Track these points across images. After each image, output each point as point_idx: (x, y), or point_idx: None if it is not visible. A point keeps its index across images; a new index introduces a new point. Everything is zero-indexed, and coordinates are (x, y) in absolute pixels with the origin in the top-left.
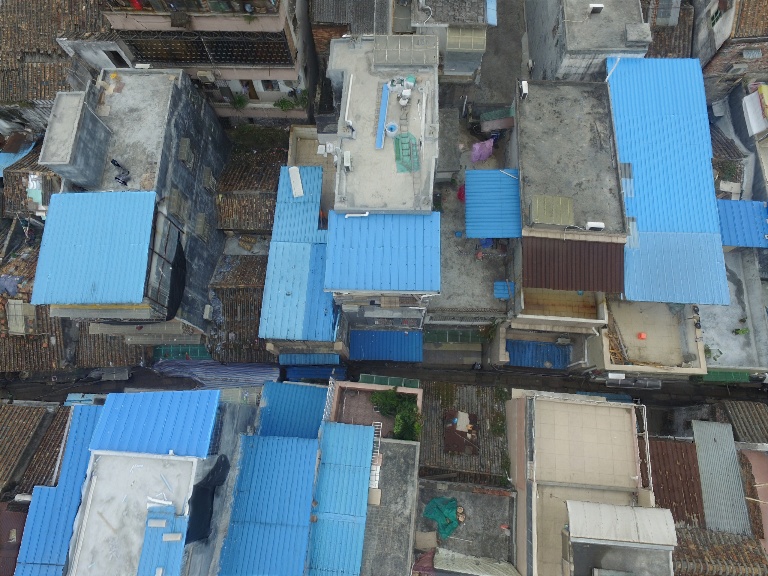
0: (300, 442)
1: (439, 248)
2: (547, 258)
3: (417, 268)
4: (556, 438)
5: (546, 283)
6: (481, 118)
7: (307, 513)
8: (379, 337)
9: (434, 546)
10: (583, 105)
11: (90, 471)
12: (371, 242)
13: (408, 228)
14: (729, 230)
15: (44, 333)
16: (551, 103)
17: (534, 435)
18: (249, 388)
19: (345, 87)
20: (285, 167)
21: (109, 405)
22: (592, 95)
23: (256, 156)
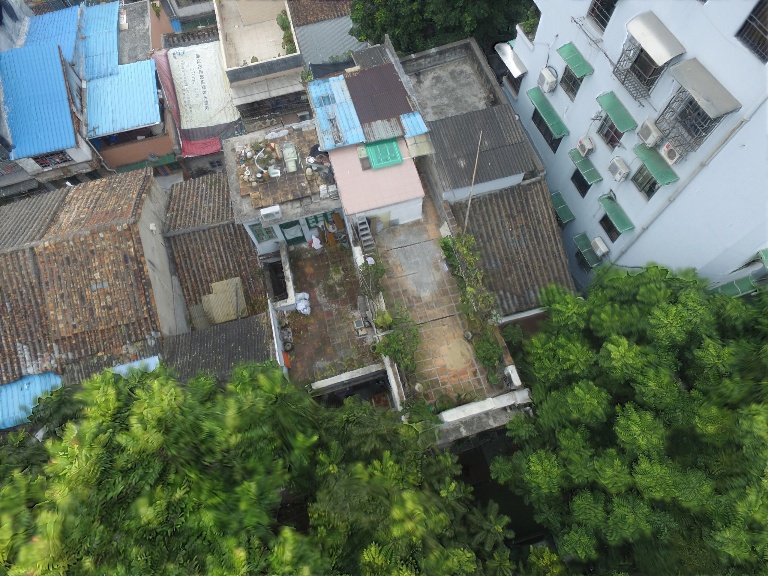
0: (67, 9)
1: None
2: None
3: None
4: None
5: None
6: None
7: (74, 27)
8: None
9: None
10: None
11: None
12: None
13: None
14: None
15: None
16: None
17: None
18: None
19: None
20: None
21: None
22: None
23: None
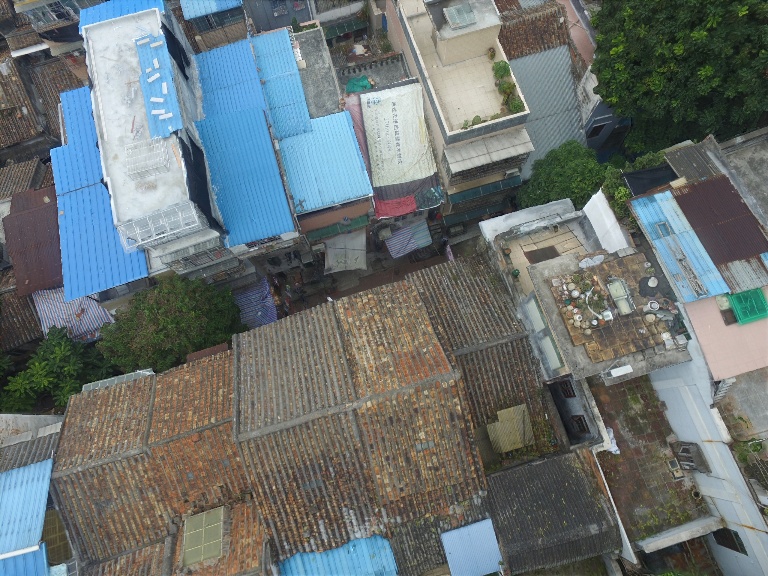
0: (236, 44)
1: None
2: None
3: None
4: None
5: None
6: None
7: (255, 72)
8: None
9: None
10: None
11: (85, 36)
12: None
13: None
14: None
15: (15, 106)
16: None
17: None
18: None
19: None
20: None
21: (83, 14)
22: None
23: None
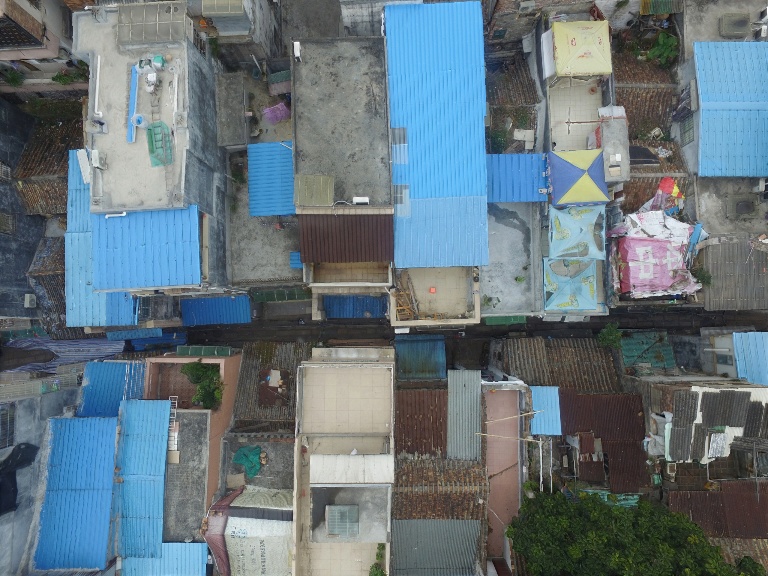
0: (101, 421)
1: (197, 242)
2: (321, 234)
3: (178, 263)
4: (326, 397)
5: (322, 258)
6: (268, 80)
7: (110, 479)
8: (208, 303)
9: (243, 484)
10: (360, 64)
11: None
12: (133, 241)
13: (167, 224)
14: (506, 186)
15: None
16: (328, 64)
17: None
18: None
19: (92, 72)
20: (73, 151)
21: None
22: (370, 51)
23: (61, 129)
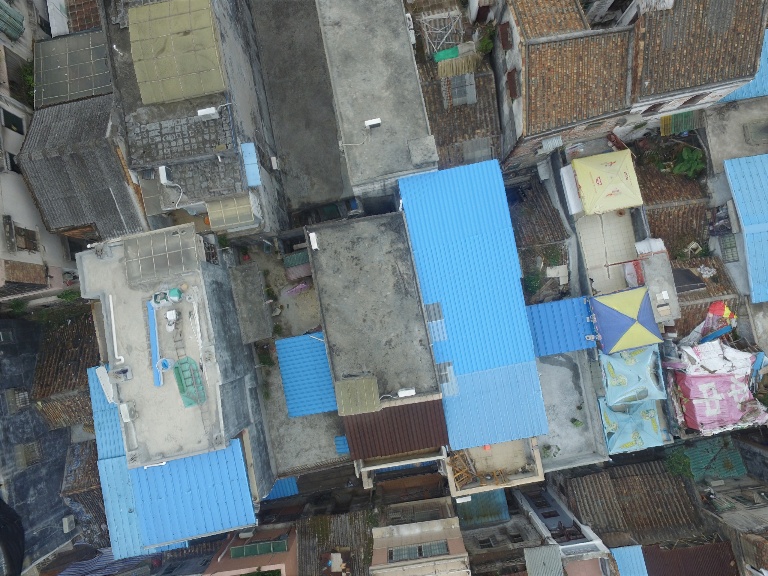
0: None
1: (246, 479)
2: (369, 429)
3: (229, 505)
4: None
5: (373, 453)
6: (284, 264)
7: None
8: None
9: None
10: (381, 243)
11: None
12: (177, 488)
13: (211, 464)
14: (551, 337)
15: None
16: (347, 248)
17: None
18: (136, 570)
19: (106, 315)
20: (91, 369)
21: None
22: (389, 228)
23: (71, 328)
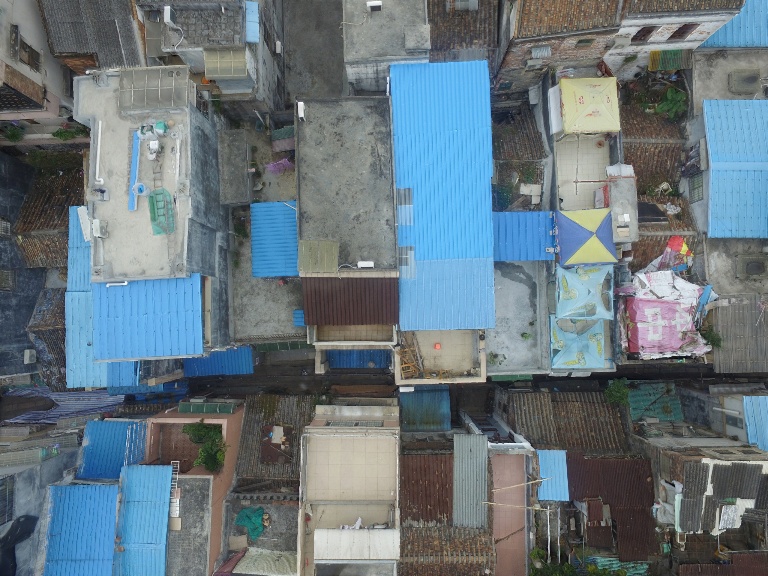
0: (102, 489)
1: (200, 312)
2: (325, 296)
3: (180, 333)
4: (330, 463)
5: (326, 320)
6: (272, 136)
7: (110, 549)
8: None
9: (245, 546)
10: (365, 124)
11: None
12: (135, 310)
13: (169, 293)
14: (513, 245)
15: None
16: (332, 123)
17: (300, 470)
18: (87, 416)
19: (93, 138)
20: (73, 207)
21: None
22: (375, 111)
23: (62, 179)
